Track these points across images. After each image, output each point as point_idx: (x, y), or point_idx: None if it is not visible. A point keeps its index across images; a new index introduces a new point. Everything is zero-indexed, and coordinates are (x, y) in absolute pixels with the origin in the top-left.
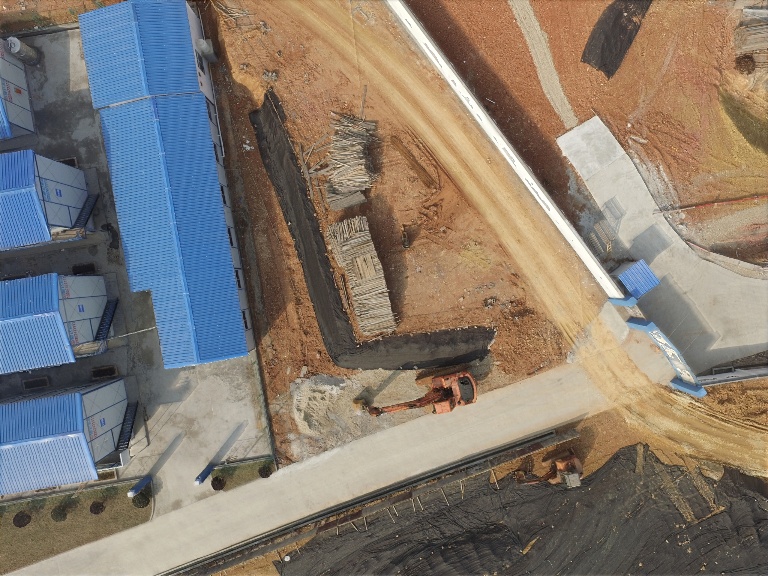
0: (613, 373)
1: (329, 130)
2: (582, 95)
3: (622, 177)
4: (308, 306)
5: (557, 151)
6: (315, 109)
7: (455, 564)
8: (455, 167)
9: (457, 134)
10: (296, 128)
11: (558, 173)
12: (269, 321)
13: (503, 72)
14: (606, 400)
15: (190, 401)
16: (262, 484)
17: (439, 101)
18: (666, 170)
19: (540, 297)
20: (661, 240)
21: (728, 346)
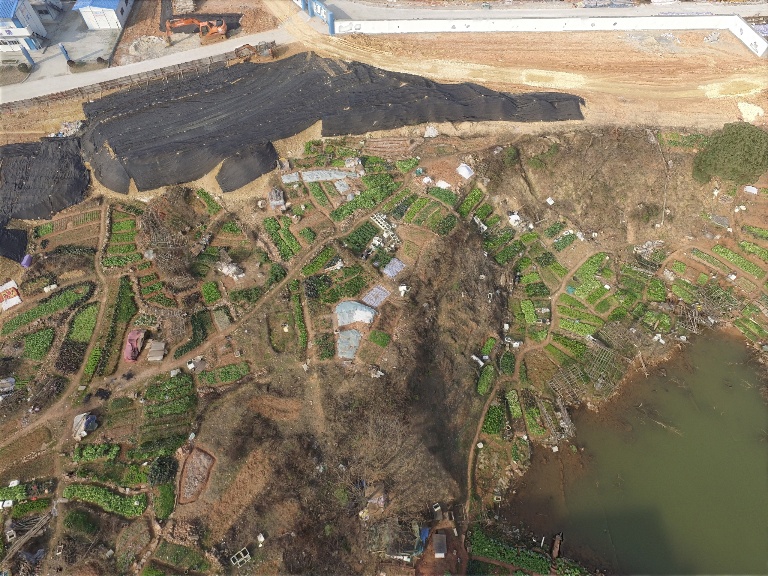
0: None
1: None
2: None
3: None
4: None
5: None
6: None
7: None
8: None
9: None
10: None
11: None
12: (135, 22)
13: None
14: (295, 39)
15: (77, 42)
16: (96, 73)
17: None
18: None
19: (269, 8)
20: None
21: None
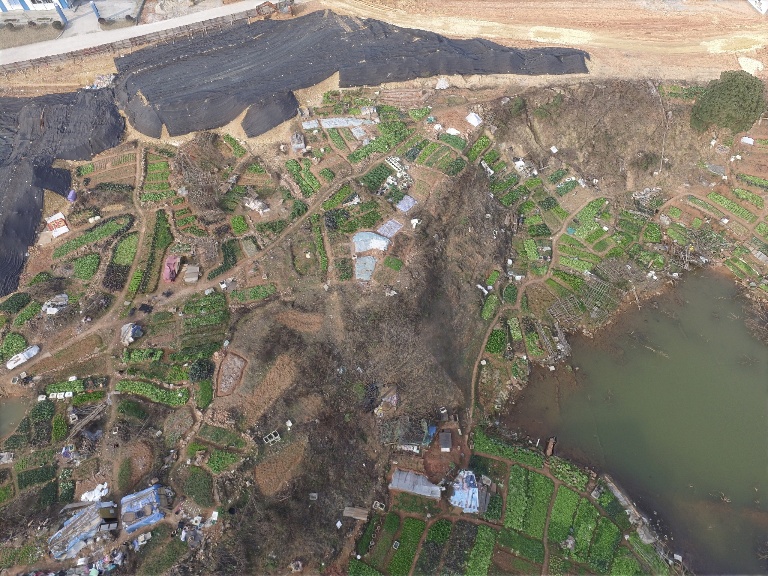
0: None
1: None
2: None
3: None
4: None
5: None
6: None
7: None
8: None
9: None
10: None
11: None
12: None
13: None
14: None
15: (106, 2)
16: (125, 30)
17: None
18: None
19: None
20: None
21: None
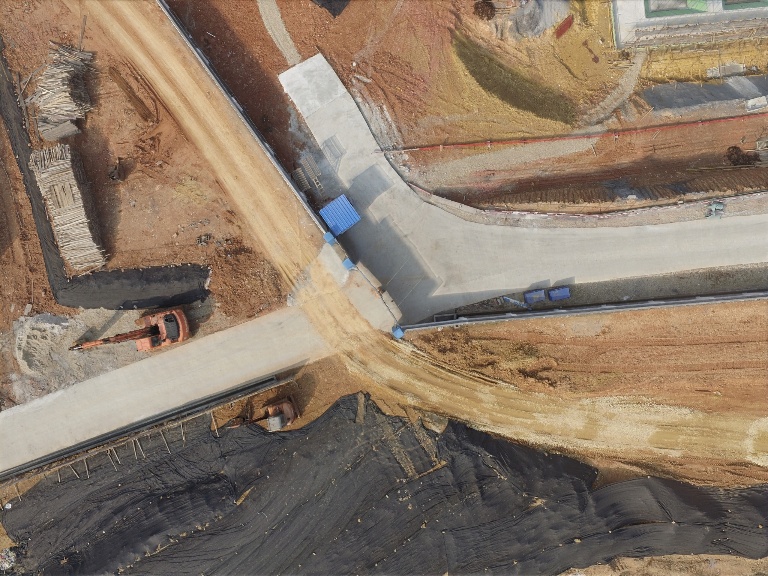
0: (334, 318)
1: (48, 60)
2: (305, 32)
3: (343, 115)
4: (36, 243)
5: (279, 88)
6: (35, 38)
7: (169, 514)
8: (174, 101)
9: (176, 67)
10: (15, 57)
11: (279, 110)
12: None
13: (224, 6)
14: (327, 346)
15: None
16: None
17: (159, 33)
18: (389, 110)
19: (257, 236)
20: (382, 181)
21: (451, 293)
